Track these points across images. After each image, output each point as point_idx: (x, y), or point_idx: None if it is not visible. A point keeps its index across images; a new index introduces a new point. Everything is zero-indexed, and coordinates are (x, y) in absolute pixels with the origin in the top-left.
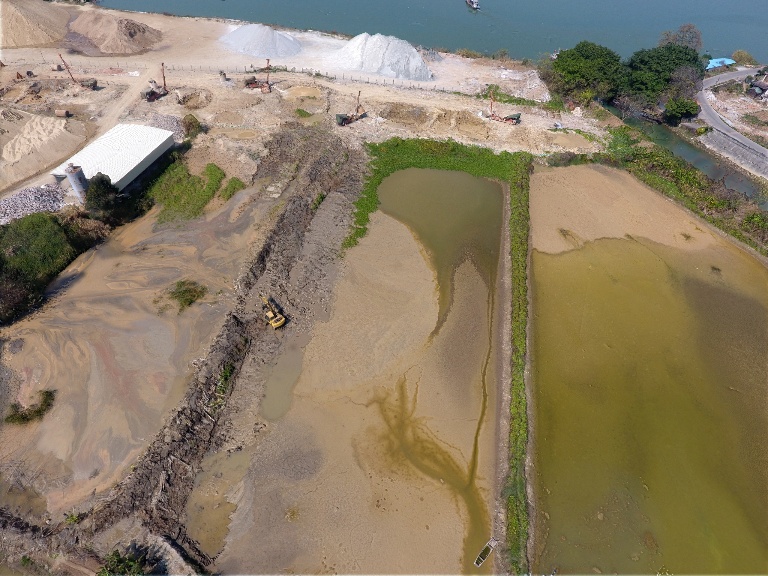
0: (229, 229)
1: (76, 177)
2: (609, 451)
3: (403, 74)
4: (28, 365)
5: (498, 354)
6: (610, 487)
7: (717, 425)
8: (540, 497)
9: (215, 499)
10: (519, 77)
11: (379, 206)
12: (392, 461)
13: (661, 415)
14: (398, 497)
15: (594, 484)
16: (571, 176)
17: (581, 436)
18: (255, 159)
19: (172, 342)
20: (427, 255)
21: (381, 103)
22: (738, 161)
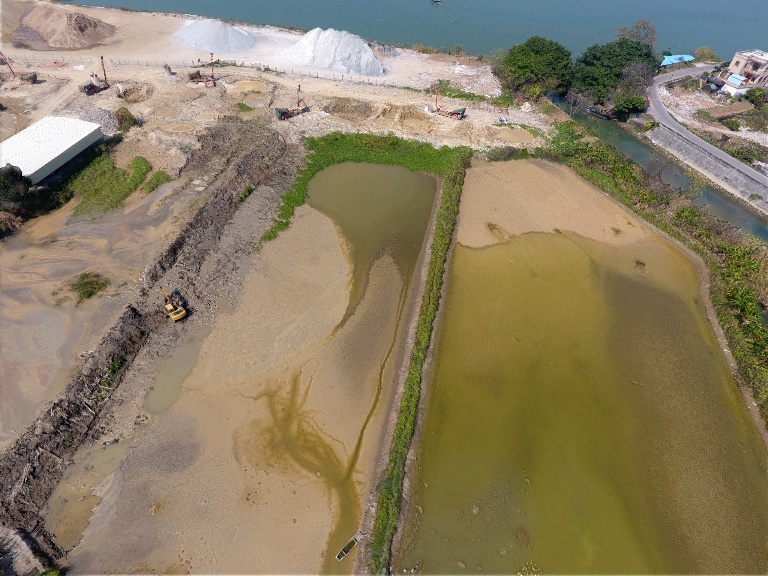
0: (145, 222)
1: None
2: (497, 445)
3: (354, 69)
4: None
5: (401, 347)
6: (491, 481)
7: (613, 419)
8: (416, 491)
9: (81, 492)
10: (473, 73)
11: (307, 200)
12: (271, 454)
13: (557, 409)
14: (270, 490)
15: (475, 478)
16: (509, 171)
17: (471, 430)
18: (186, 152)
19: (63, 334)
20: (347, 249)
21: (327, 98)
22: (682, 156)
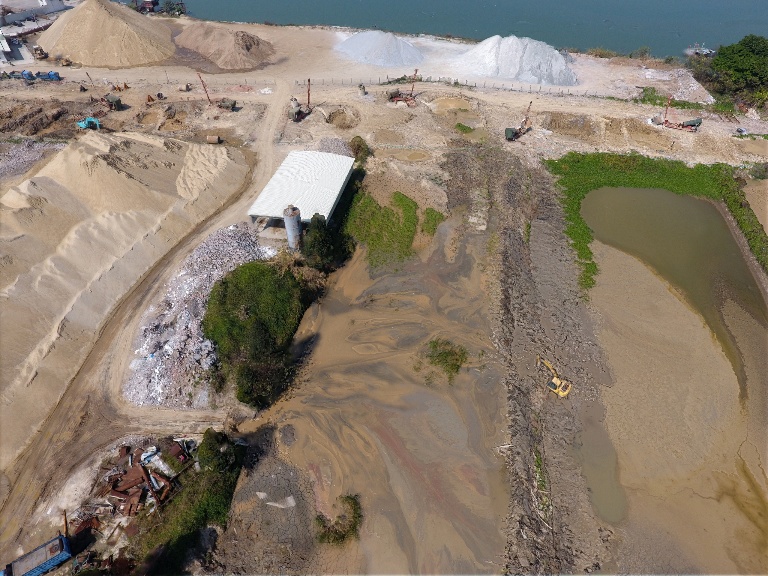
0: (453, 271)
1: (296, 220)
2: None
3: (546, 79)
4: (311, 461)
5: None
6: None
7: None
8: None
9: None
10: (666, 77)
11: (593, 235)
12: None
13: None
14: None
15: None
16: None
17: None
18: (440, 184)
19: (460, 422)
20: (679, 294)
21: (538, 113)
22: None
